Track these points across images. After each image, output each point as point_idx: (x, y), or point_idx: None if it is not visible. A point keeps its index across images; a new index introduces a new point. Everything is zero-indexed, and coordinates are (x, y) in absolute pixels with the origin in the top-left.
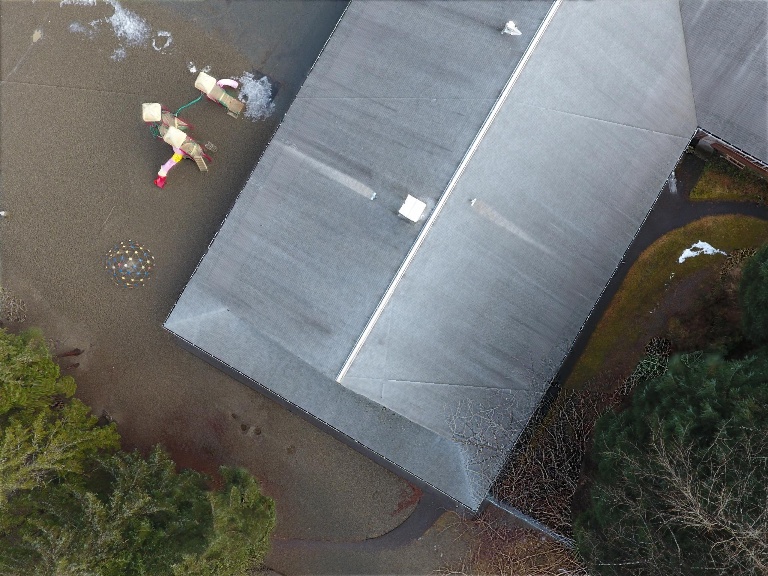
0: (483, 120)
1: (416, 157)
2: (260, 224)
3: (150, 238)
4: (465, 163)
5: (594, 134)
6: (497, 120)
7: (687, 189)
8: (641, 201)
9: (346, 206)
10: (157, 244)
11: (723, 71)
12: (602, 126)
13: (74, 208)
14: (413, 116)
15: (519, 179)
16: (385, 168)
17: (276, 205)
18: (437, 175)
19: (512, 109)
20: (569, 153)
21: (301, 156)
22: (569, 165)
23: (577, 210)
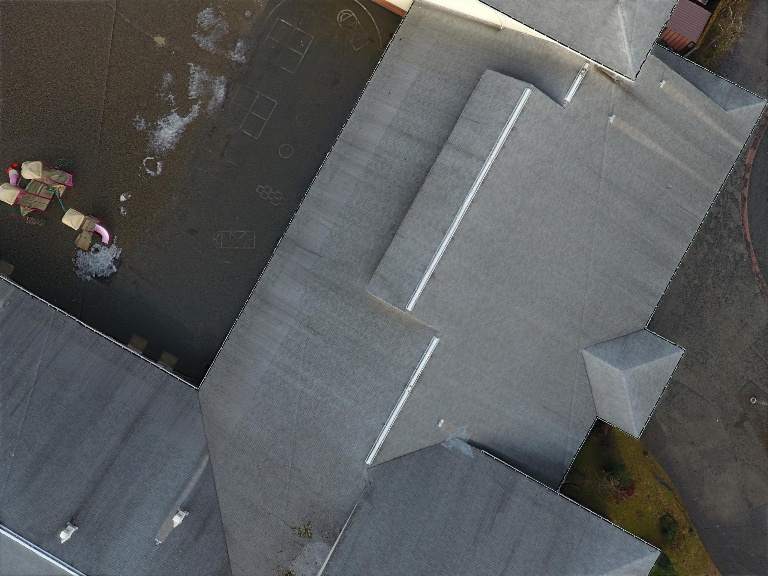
0: None
1: None
2: None
3: None
4: None
5: None
6: None
7: None
8: None
9: None
10: None
11: None
12: None
13: None
14: None
15: None
16: None
17: None
18: None
19: None
20: None
21: None
22: None
23: None
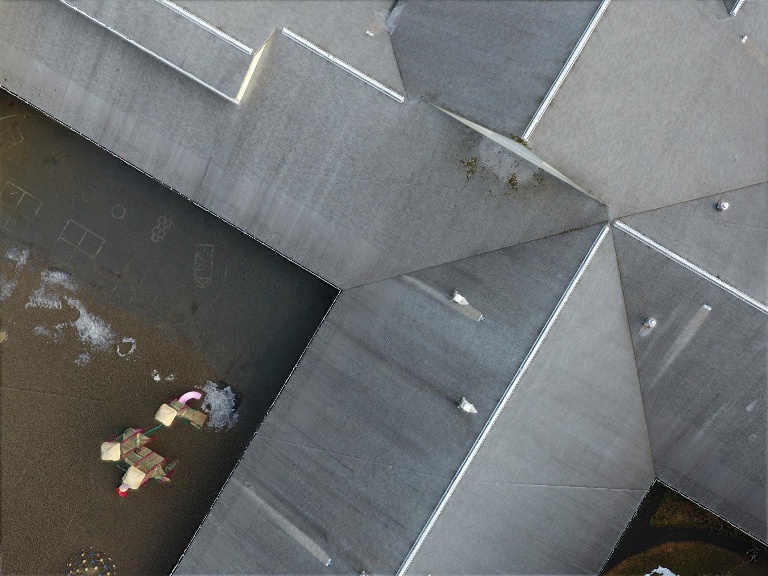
0: (437, 501)
1: (371, 527)
2: (217, 569)
3: (111, 546)
4: (419, 546)
5: (550, 499)
6: (451, 501)
7: (648, 514)
8: (598, 554)
9: (301, 567)
10: (118, 553)
11: (680, 433)
12: (558, 491)
13: (36, 513)
14: (369, 481)
15: (474, 551)
16: (341, 533)
17: (233, 551)
18: (391, 552)
19: (467, 488)
20: (525, 520)
21: (259, 502)
22: (525, 531)
23: (533, 571)
